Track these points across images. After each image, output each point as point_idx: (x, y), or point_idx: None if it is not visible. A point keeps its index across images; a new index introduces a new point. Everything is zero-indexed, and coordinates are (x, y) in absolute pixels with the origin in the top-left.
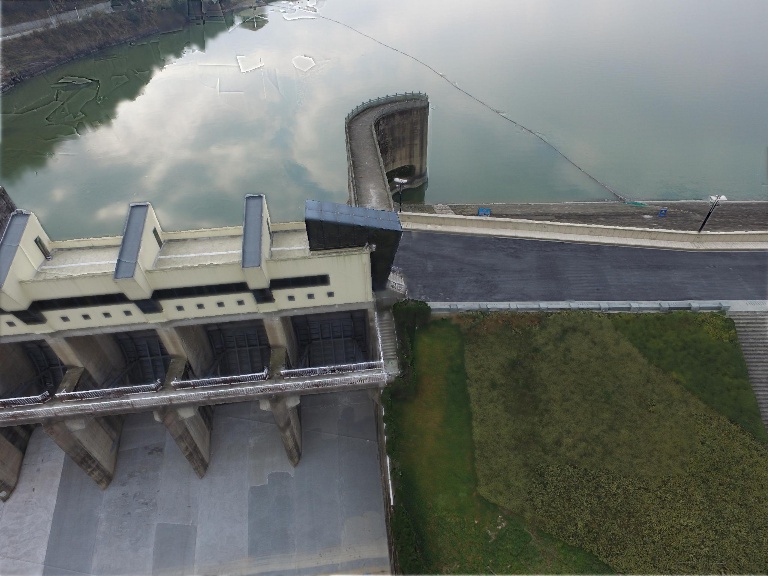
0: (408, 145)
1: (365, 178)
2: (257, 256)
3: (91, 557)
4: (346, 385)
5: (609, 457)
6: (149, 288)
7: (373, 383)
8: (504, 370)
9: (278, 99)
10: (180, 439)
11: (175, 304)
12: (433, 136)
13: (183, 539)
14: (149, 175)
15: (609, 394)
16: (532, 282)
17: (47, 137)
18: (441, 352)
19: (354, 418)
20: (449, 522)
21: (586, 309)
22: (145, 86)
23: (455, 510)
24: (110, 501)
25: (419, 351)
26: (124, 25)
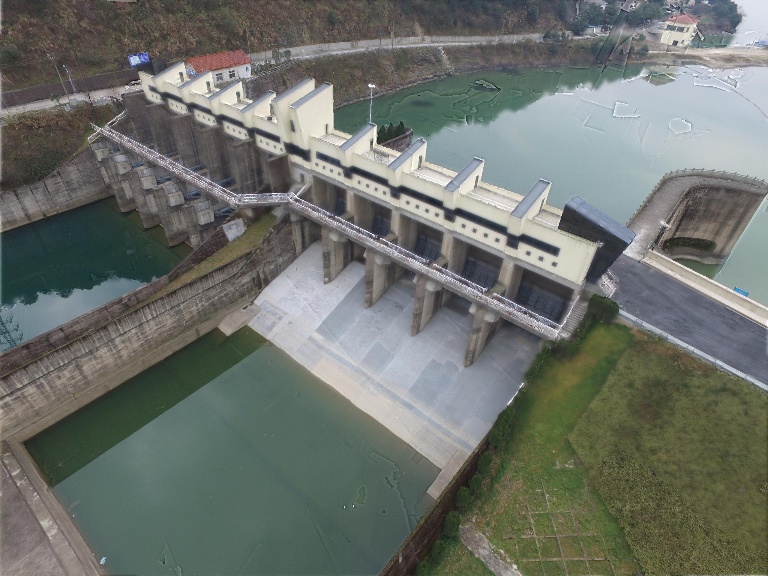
0: (720, 222)
1: (646, 220)
2: (523, 213)
3: (342, 334)
4: (528, 325)
5: (690, 489)
6: (456, 204)
7: (546, 335)
8: (647, 381)
9: (636, 150)
10: (418, 300)
11: (463, 222)
12: (754, 226)
13: (384, 358)
14: (493, 163)
15: (728, 453)
16: (727, 348)
17: (447, 115)
18: (607, 345)
19: (521, 368)
20: (536, 440)
21: (760, 388)
22: (531, 104)
23: (545, 437)
24: (364, 316)
25: (592, 336)
26: (544, 54)
